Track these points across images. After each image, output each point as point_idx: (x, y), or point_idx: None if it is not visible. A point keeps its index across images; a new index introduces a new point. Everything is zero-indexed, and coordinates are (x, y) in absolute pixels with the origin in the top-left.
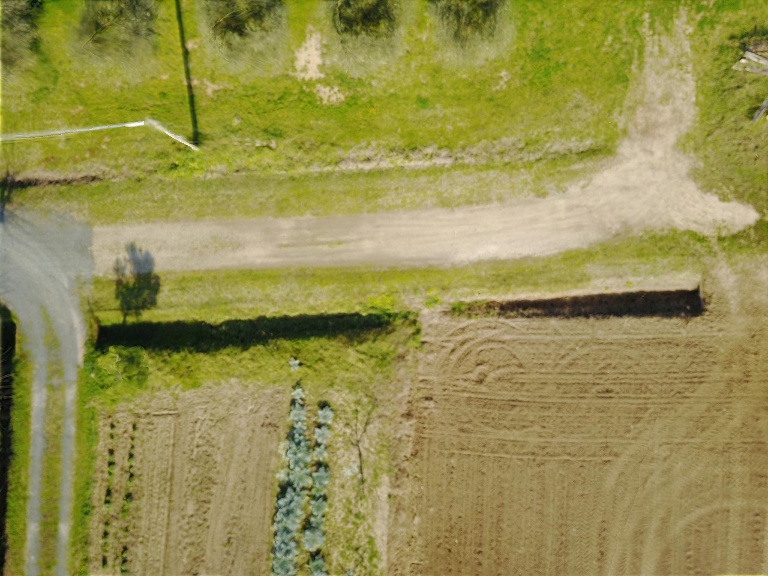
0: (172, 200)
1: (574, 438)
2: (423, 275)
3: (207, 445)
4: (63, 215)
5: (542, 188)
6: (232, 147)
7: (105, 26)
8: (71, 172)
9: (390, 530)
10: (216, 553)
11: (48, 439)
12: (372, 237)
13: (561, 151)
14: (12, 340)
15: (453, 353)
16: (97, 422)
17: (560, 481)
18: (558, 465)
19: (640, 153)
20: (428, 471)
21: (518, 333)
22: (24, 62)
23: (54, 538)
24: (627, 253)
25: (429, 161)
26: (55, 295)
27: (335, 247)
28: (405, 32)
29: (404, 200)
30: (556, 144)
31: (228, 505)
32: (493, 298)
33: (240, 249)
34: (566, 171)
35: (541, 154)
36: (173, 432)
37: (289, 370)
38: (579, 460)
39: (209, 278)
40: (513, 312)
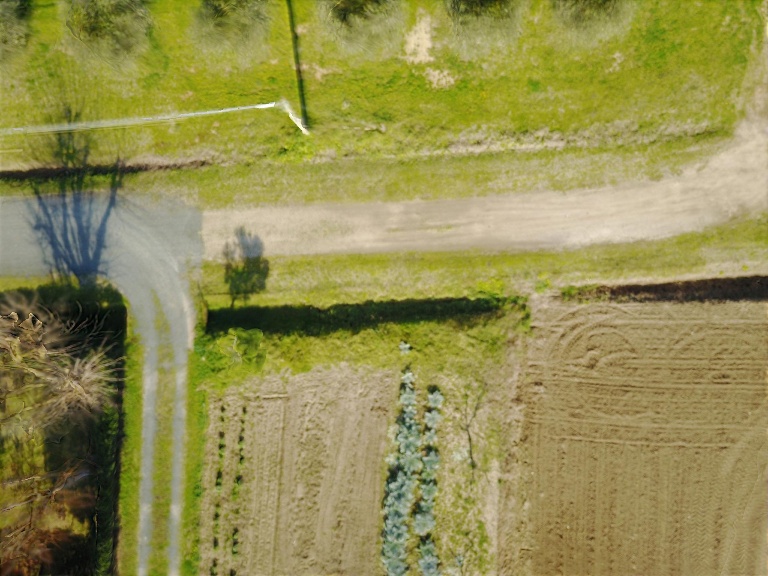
0: (281, 184)
1: (689, 424)
2: (534, 259)
3: (317, 429)
4: (173, 200)
5: (656, 171)
6: (341, 131)
7: (226, 10)
8: (181, 157)
9: (500, 515)
10: (326, 536)
11: (160, 421)
12: (482, 221)
13: (676, 133)
14: (123, 323)
15: (563, 338)
16: (208, 405)
17: (675, 468)
18: (673, 452)
19: (758, 135)
20: (538, 457)
21: (630, 318)
22: (138, 47)
23: (166, 519)
24: (744, 237)
25: (540, 144)
26: (166, 279)
27: (444, 231)
28: (519, 14)
29: (515, 184)
30: (671, 126)
31: (338, 488)
32: (603, 283)
33: (349, 233)
34: (681, 154)
35: (655, 136)
36: (283, 415)
37: (399, 354)
38: (694, 447)
39: (318, 262)
40: (625, 297)
